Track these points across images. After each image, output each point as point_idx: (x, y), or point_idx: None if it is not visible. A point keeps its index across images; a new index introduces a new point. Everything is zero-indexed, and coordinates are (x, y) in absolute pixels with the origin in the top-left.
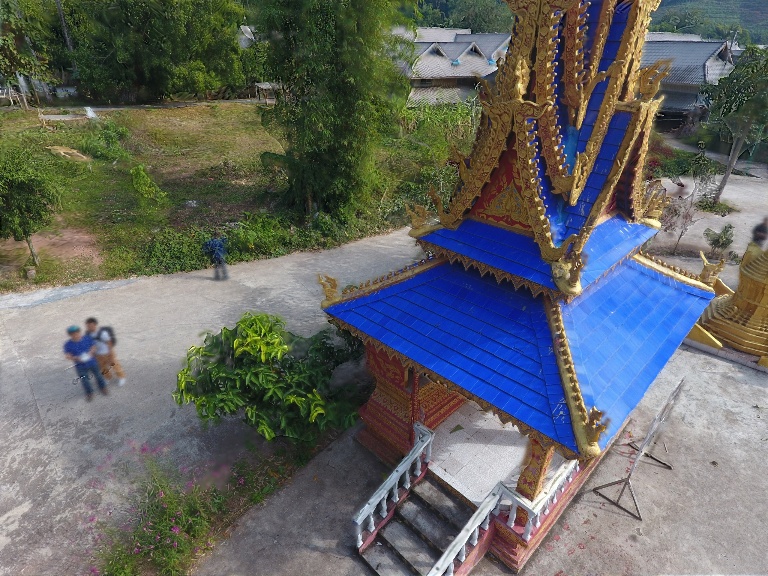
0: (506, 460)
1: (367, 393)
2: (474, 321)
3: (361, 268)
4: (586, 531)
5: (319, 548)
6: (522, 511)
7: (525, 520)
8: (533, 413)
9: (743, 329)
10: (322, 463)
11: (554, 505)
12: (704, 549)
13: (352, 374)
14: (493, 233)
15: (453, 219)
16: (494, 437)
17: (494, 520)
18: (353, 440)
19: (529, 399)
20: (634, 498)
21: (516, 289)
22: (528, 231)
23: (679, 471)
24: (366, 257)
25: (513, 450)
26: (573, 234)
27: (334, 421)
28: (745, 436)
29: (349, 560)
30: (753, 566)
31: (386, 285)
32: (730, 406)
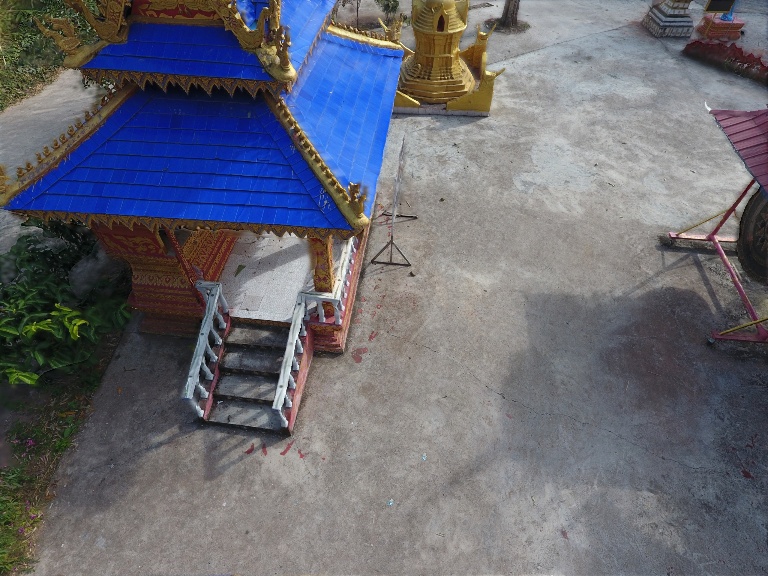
0: (296, 273)
1: (126, 283)
2: (204, 148)
3: (28, 148)
4: (378, 294)
5: (163, 442)
6: (327, 304)
7: (332, 310)
8: (302, 214)
9: (429, 83)
10: (117, 373)
11: (349, 287)
12: (454, 263)
13: (95, 273)
14: (174, 33)
15: (115, 27)
16: (277, 260)
17: (308, 325)
18: (139, 335)
19: (293, 203)
20: (401, 252)
21: (232, 95)
22: (214, 20)
23: (422, 217)
24: (26, 132)
25: (298, 262)
26: (263, 10)
27: (104, 325)
28: (454, 170)
29: (199, 432)
30: (483, 257)
31: (74, 145)
32: (439, 152)
